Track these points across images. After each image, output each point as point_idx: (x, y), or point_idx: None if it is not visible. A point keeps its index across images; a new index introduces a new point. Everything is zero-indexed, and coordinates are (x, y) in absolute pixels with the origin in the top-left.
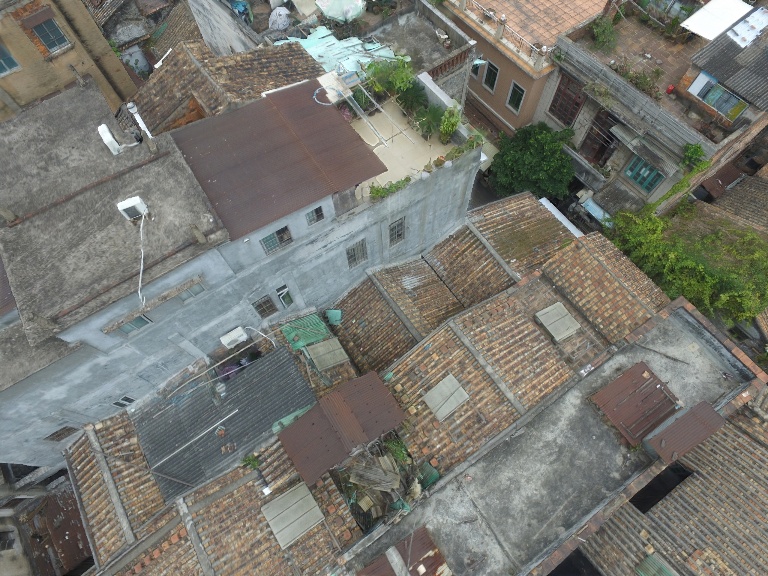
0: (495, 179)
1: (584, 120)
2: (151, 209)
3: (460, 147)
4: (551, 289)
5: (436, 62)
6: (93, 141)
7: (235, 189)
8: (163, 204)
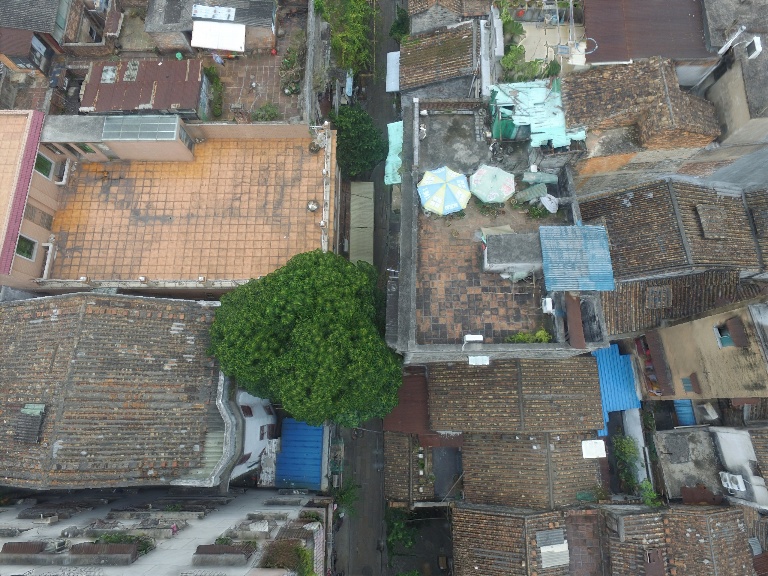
0: (384, 152)
1: (318, 106)
2: (737, 2)
3: (513, 2)
4: (463, 7)
5: (455, 100)
6: (763, 63)
7: (680, 5)
8: (730, 1)
